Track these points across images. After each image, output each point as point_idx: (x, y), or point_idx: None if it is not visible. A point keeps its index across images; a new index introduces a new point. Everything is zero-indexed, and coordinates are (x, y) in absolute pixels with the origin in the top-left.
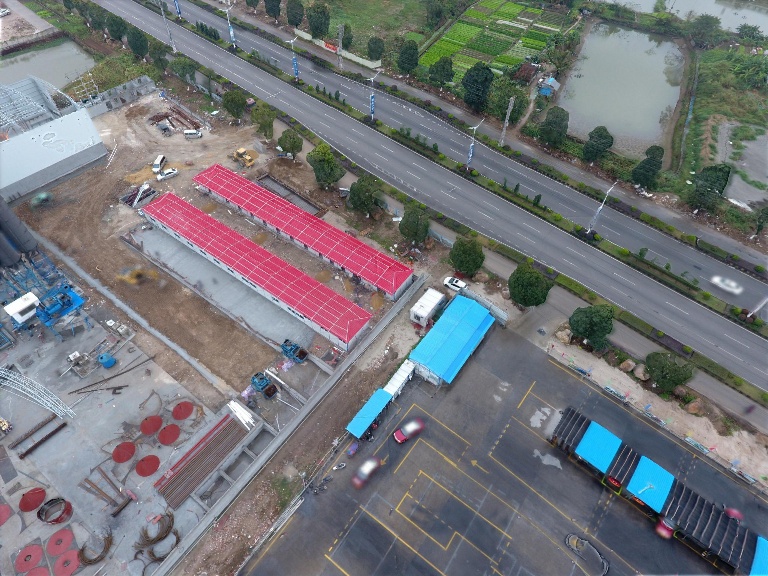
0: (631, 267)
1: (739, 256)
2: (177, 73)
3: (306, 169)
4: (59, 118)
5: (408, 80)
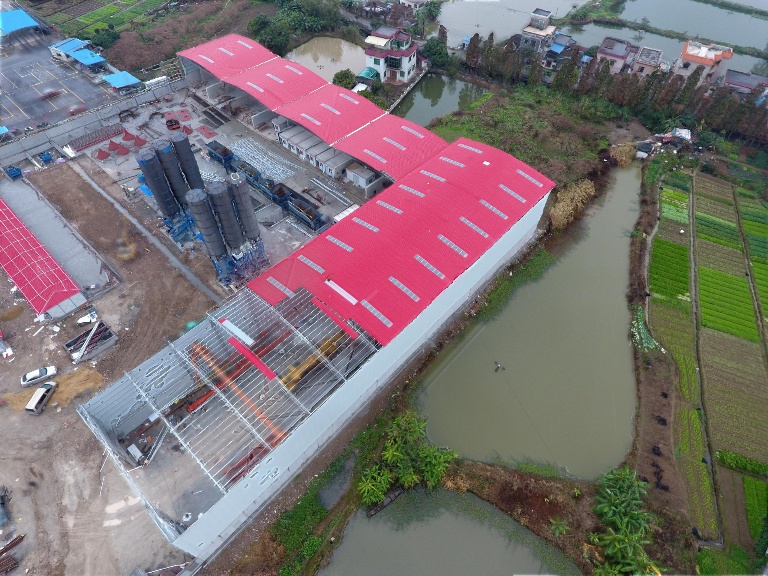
0: None
1: None
2: None
3: None
4: (121, 379)
5: None
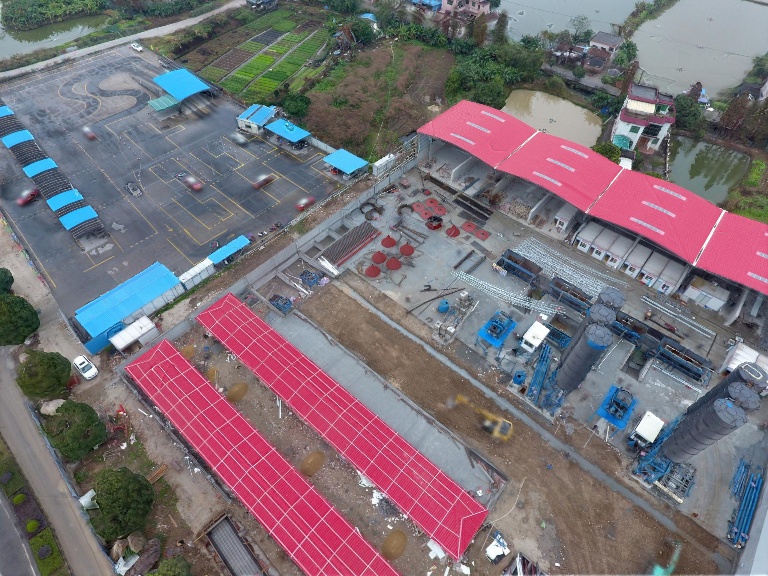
0: None
1: None
2: None
3: None
4: None
5: None
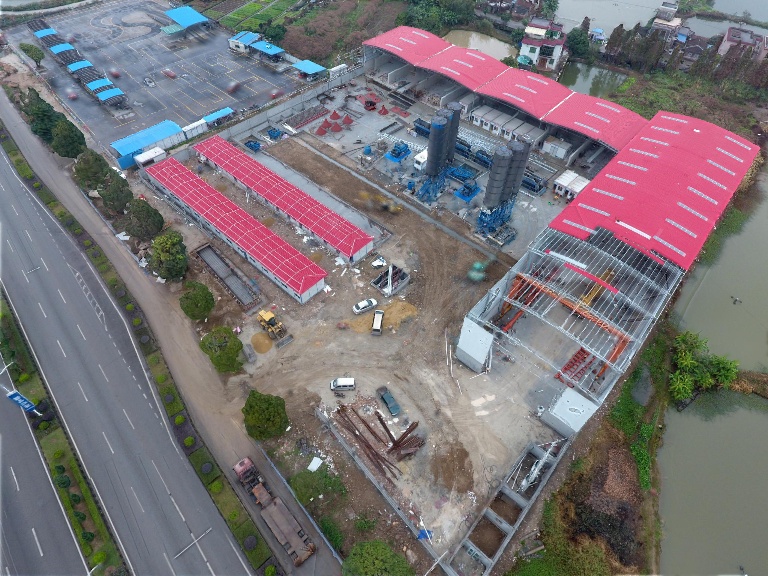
0: None
1: None
2: None
3: None
4: (486, 295)
5: None
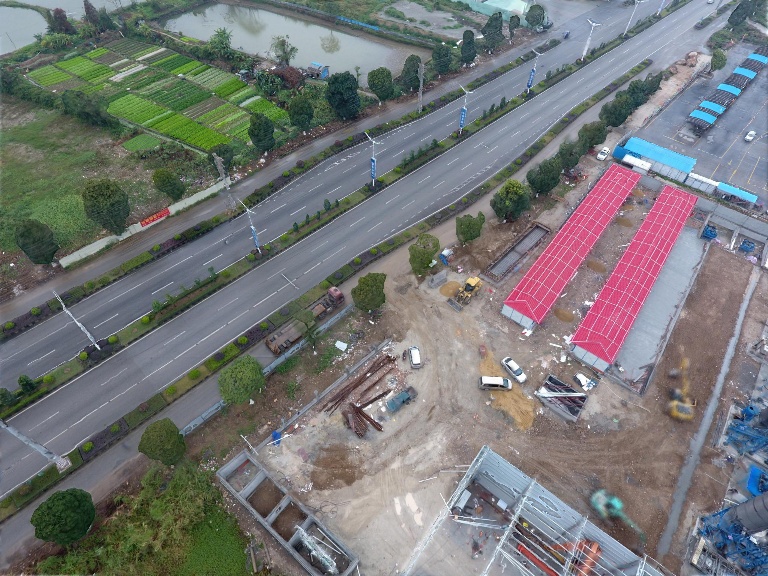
0: (552, 86)
1: None
2: None
3: None
4: (527, 477)
5: (273, 156)
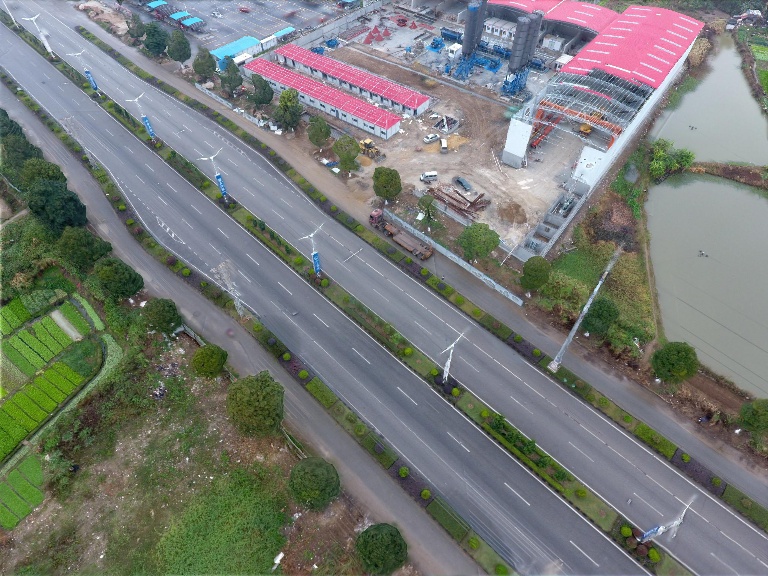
0: None
1: (2, 85)
2: (511, 296)
3: (310, 150)
4: (523, 108)
5: (136, 295)
